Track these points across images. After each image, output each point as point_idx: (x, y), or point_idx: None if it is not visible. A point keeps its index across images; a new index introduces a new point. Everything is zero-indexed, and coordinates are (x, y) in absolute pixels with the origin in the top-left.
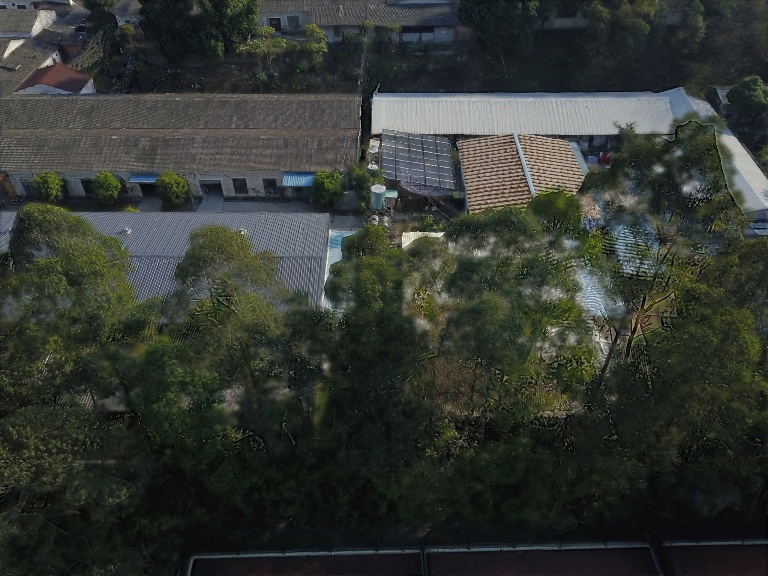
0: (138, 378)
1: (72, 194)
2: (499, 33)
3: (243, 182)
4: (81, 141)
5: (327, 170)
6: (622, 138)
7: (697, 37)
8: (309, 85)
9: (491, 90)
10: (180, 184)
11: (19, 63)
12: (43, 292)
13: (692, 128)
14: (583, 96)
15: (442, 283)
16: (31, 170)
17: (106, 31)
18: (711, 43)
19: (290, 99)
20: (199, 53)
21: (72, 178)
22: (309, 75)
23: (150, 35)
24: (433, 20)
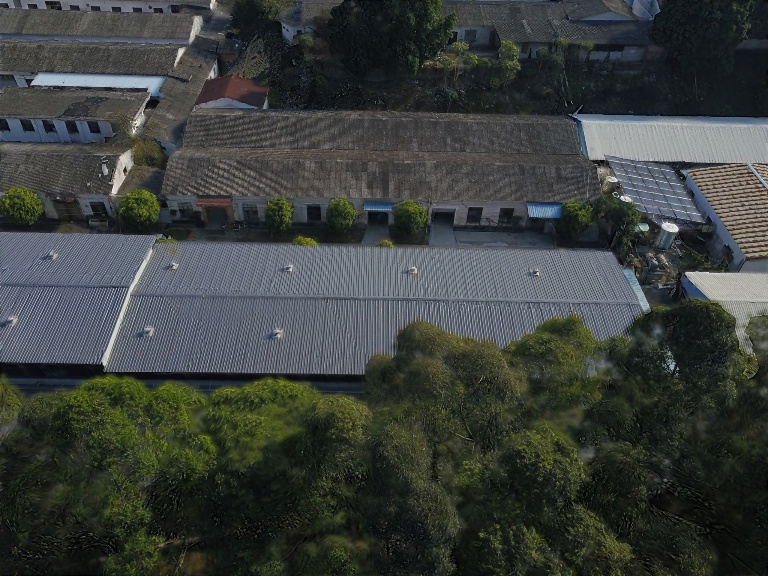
0: (747, 486)
1: (293, 220)
2: (701, 55)
3: (479, 211)
4: (305, 164)
5: None
6: None
7: None
8: (498, 104)
9: (683, 113)
10: (422, 213)
11: (191, 73)
12: (724, 402)
13: None
14: None
15: None
16: (259, 195)
17: (270, 40)
18: None
19: (502, 121)
20: (383, 67)
21: (299, 204)
22: (496, 93)
23: (339, 48)
24: (624, 38)
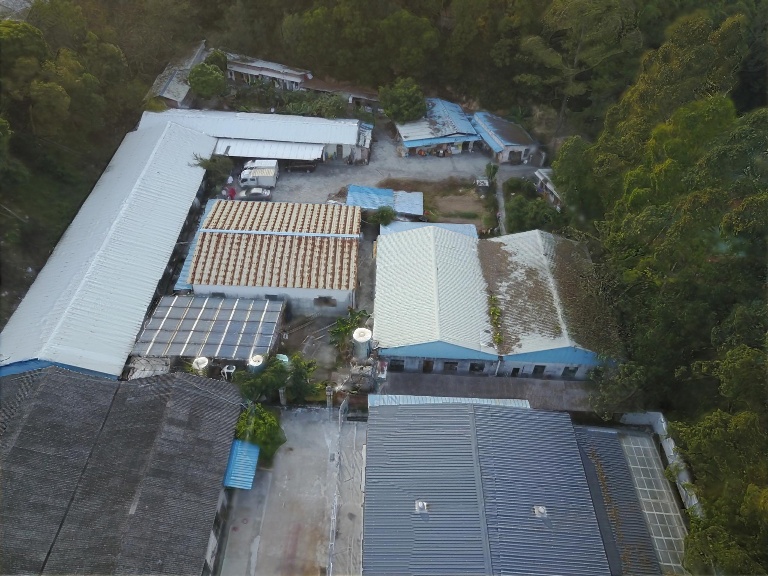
0: None
1: None
2: None
3: (204, 567)
4: None
5: (234, 422)
6: (213, 170)
7: (123, 63)
8: None
9: (40, 244)
10: None
11: None
12: None
13: (709, 21)
14: (131, 170)
15: (761, 189)
16: None
17: None
18: (130, 62)
19: None
20: None
21: None
22: None
23: None
24: None
